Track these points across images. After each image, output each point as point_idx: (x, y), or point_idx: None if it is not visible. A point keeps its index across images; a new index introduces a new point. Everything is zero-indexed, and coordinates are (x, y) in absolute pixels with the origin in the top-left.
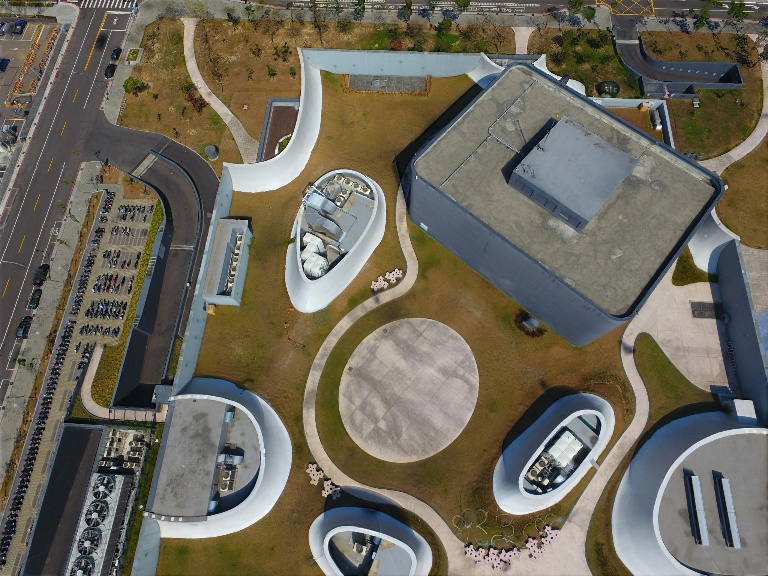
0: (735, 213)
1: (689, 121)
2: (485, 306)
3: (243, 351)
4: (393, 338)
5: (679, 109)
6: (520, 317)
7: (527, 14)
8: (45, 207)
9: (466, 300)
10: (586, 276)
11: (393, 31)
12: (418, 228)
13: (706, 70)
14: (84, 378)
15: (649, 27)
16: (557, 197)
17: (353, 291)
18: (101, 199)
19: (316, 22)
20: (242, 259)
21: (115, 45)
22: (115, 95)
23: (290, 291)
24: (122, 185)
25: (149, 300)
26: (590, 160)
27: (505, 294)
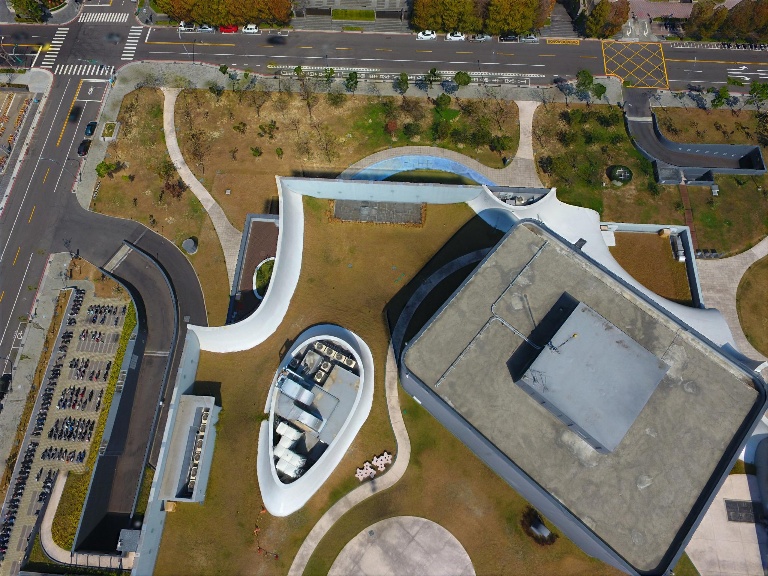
0: (760, 321)
1: (708, 212)
2: (487, 502)
3: (206, 562)
4: (381, 543)
5: (697, 198)
6: (528, 520)
7: (532, 86)
8: (9, 306)
9: (465, 494)
10: (608, 514)
11: (388, 104)
12: (411, 397)
13: (725, 151)
14: (45, 513)
15: (663, 102)
16: (574, 417)
17: (335, 481)
18: (69, 299)
19: (305, 93)
20: (207, 447)
21: (90, 118)
22: (88, 176)
23: (262, 485)
24: (93, 281)
25: (118, 420)
26: (612, 365)
27: (510, 486)
